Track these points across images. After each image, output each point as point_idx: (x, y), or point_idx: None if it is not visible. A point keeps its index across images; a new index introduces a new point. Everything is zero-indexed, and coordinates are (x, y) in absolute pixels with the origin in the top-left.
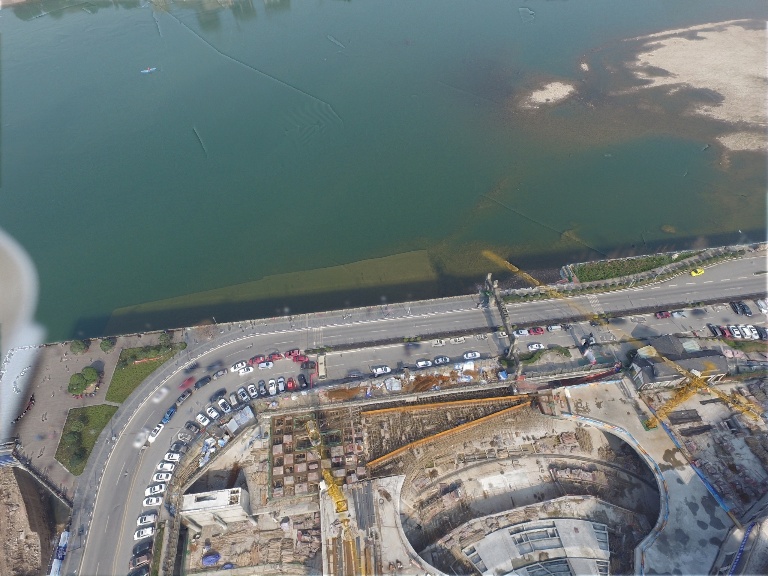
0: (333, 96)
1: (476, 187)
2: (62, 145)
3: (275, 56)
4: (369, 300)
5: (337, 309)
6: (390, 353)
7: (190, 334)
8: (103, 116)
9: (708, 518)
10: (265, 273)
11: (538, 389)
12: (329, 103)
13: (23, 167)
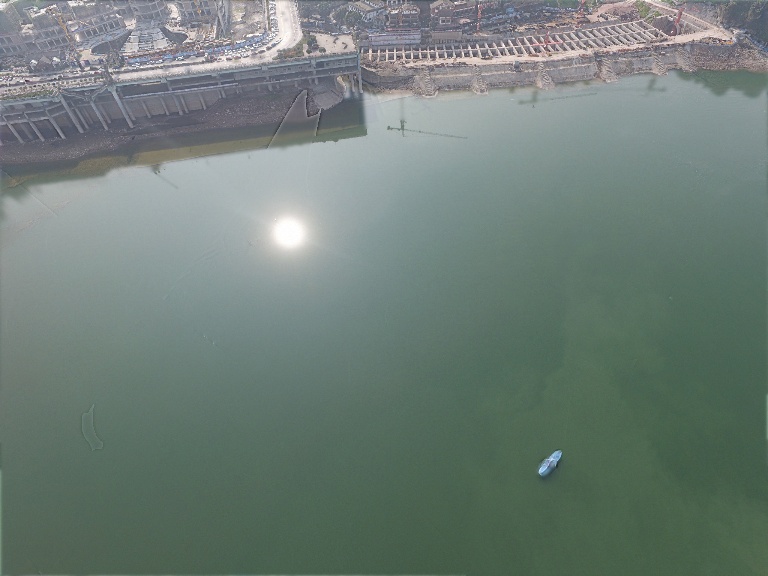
0: (160, 392)
1: (55, 223)
2: (537, 256)
3: (264, 549)
4: (190, 139)
5: (212, 134)
6: None
7: None
8: (526, 310)
9: (84, 43)
10: (261, 149)
11: None
12: (171, 366)
13: (551, 223)
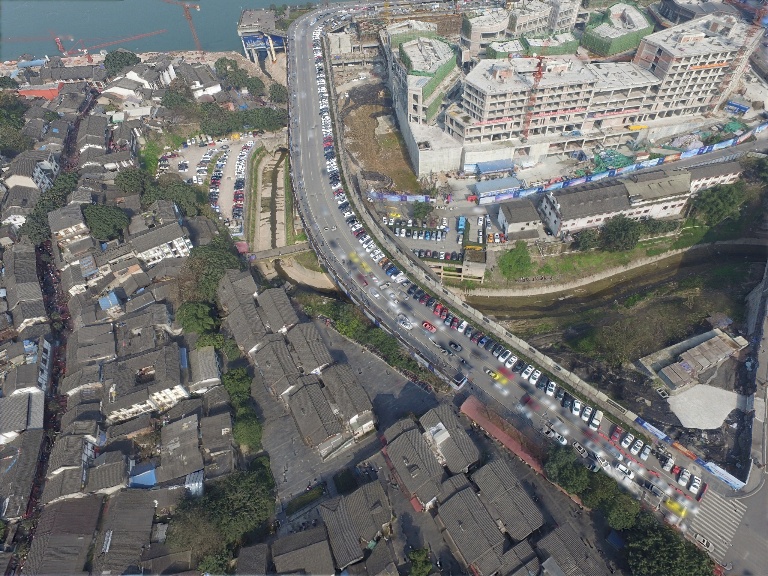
0: None
1: None
2: None
3: None
4: None
5: None
6: (404, 7)
7: (318, 6)
8: None
9: None
10: None
11: (465, 12)
12: None
13: None
